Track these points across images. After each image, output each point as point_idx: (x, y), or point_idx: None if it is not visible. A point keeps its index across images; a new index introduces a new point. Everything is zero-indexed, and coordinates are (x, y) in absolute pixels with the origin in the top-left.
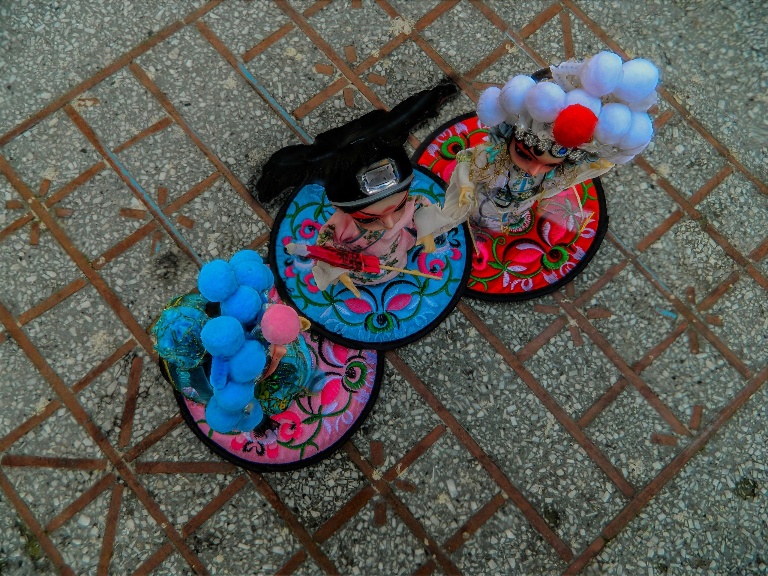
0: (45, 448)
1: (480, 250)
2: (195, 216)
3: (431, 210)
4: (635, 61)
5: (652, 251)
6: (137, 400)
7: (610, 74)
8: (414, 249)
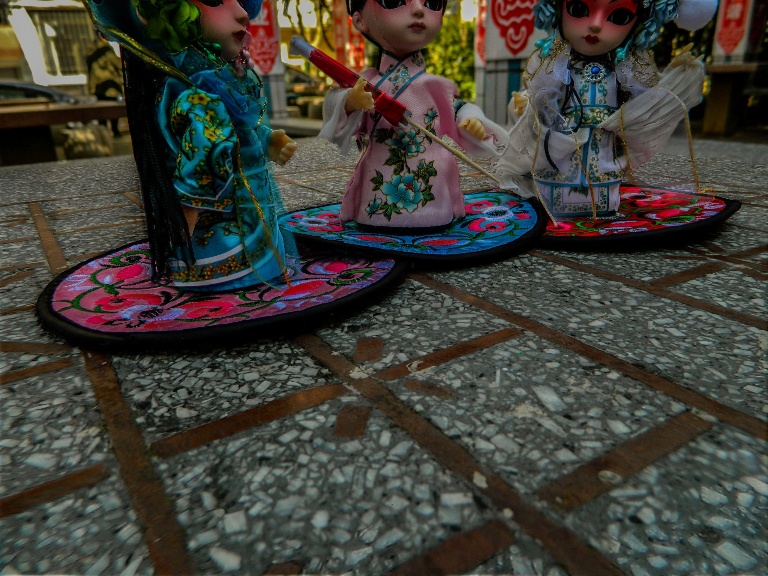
0: None
1: (558, 224)
2: None
3: None
4: None
5: None
6: None
7: None
8: None
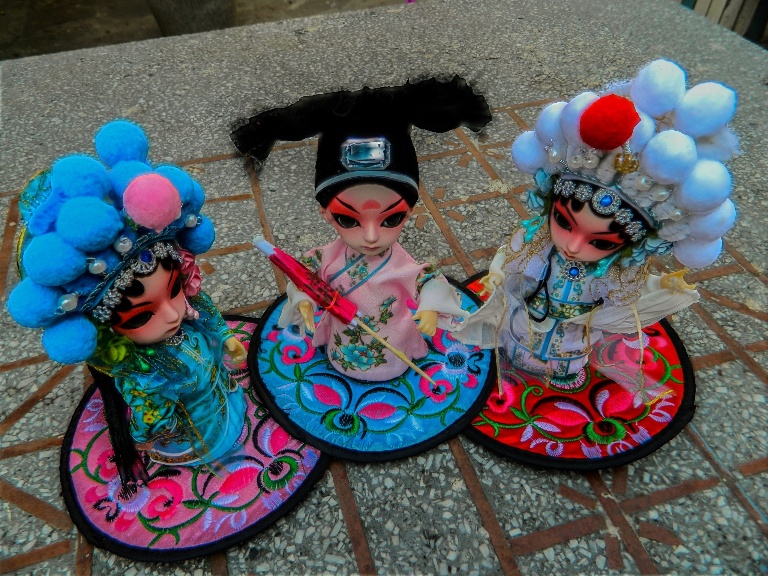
0: None
1: (505, 391)
2: (219, 266)
3: (444, 287)
4: None
5: (763, 481)
6: (37, 403)
7: (663, 75)
8: (423, 362)
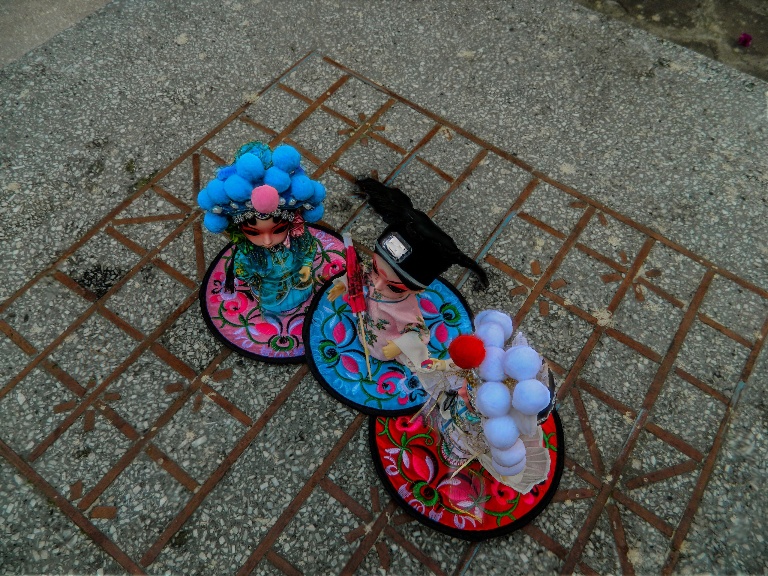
0: (205, 172)
1: (415, 423)
2: None
3: (418, 342)
4: (543, 385)
5: None
6: None
7: (515, 359)
8: (400, 366)
